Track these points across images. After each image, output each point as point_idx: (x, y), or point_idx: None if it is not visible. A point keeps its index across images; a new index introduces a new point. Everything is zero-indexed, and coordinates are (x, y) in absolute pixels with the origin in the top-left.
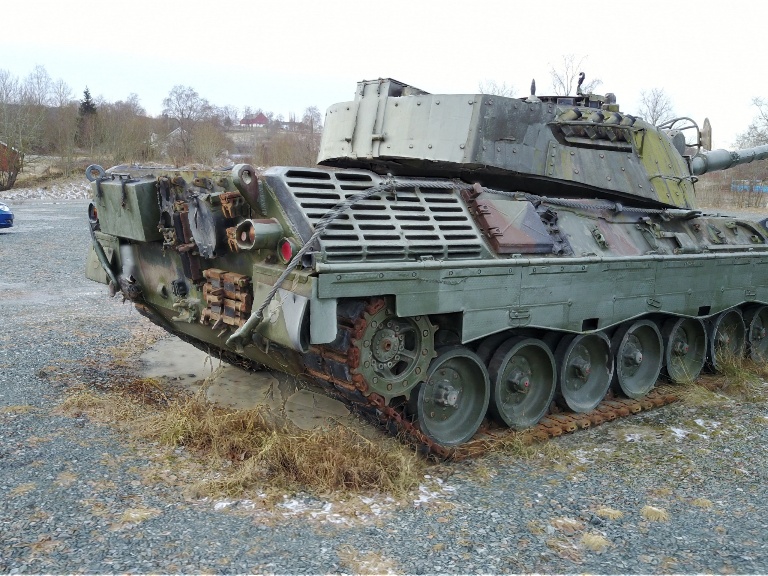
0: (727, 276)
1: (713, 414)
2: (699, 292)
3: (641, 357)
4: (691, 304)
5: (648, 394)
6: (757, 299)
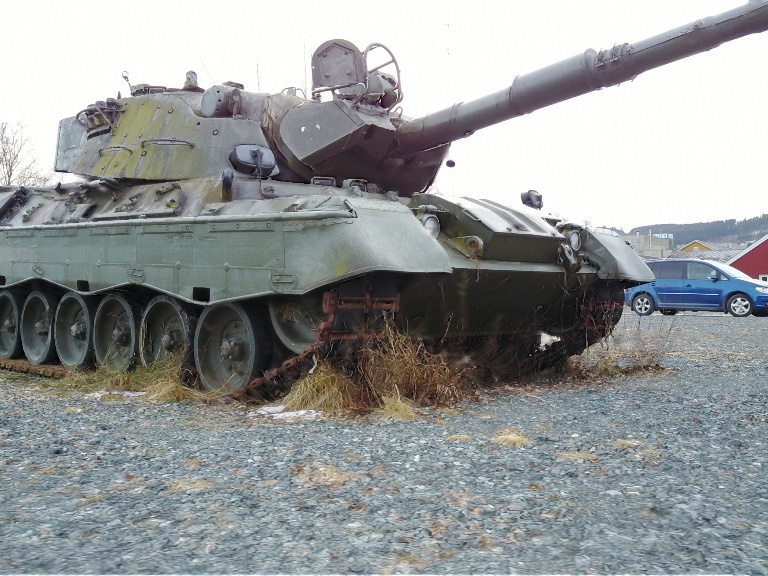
0: (104, 248)
1: (13, 381)
2: (76, 264)
3: (74, 330)
4: (70, 276)
5: (74, 369)
6: (149, 283)
